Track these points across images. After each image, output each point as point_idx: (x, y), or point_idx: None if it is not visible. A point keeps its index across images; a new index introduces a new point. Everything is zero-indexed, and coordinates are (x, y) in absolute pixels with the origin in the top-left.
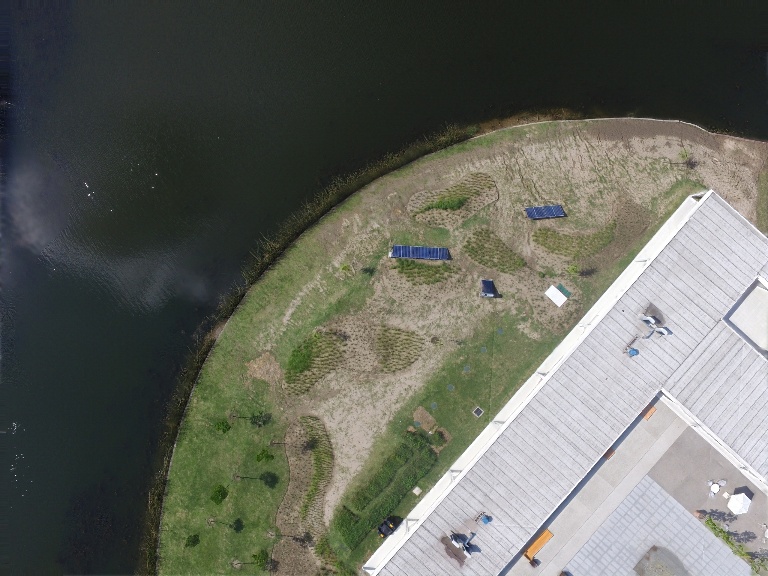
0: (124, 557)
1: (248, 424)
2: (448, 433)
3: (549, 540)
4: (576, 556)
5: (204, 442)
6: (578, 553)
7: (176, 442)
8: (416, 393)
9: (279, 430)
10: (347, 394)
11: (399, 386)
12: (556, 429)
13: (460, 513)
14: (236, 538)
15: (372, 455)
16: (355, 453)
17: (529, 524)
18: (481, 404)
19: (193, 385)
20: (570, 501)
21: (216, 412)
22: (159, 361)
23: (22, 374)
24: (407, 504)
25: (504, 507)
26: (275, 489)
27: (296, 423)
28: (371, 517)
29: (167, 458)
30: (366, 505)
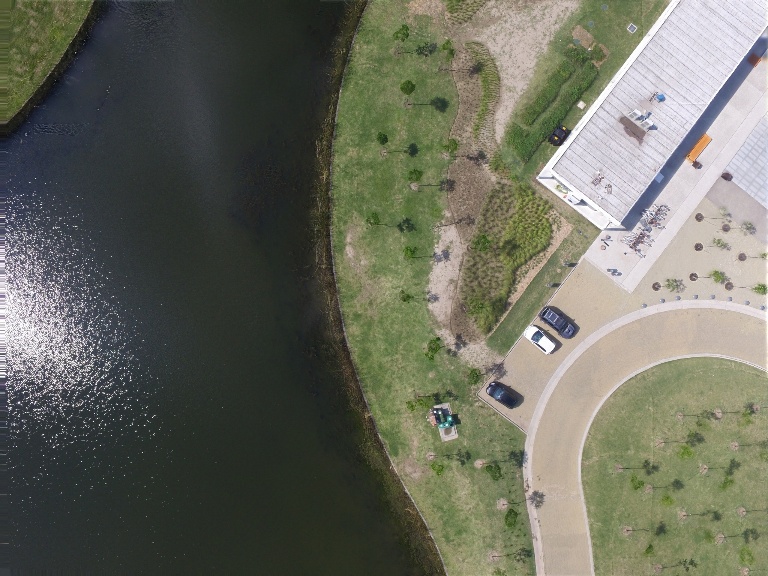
0: (295, 207)
1: (414, 56)
2: (606, 49)
3: (708, 144)
4: (734, 158)
5: (370, 82)
6: (736, 156)
7: (341, 88)
8: (573, 14)
9: (445, 58)
10: (508, 20)
11: (556, 8)
12: (716, 13)
13: (635, 94)
14: (411, 162)
15: (536, 74)
16: (520, 73)
17: (699, 101)
18: (634, 21)
19: (354, 33)
20: (724, 107)
21: (380, 53)
22: (317, 18)
23: (183, 39)
24: (573, 117)
25: (675, 87)
26: (446, 113)
27: (461, 50)
28: (541, 129)
29: (332, 106)
30: (535, 120)
